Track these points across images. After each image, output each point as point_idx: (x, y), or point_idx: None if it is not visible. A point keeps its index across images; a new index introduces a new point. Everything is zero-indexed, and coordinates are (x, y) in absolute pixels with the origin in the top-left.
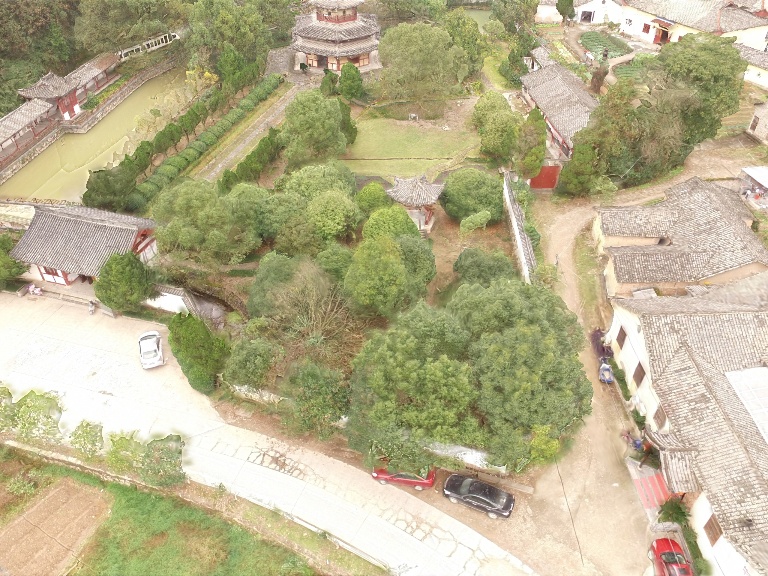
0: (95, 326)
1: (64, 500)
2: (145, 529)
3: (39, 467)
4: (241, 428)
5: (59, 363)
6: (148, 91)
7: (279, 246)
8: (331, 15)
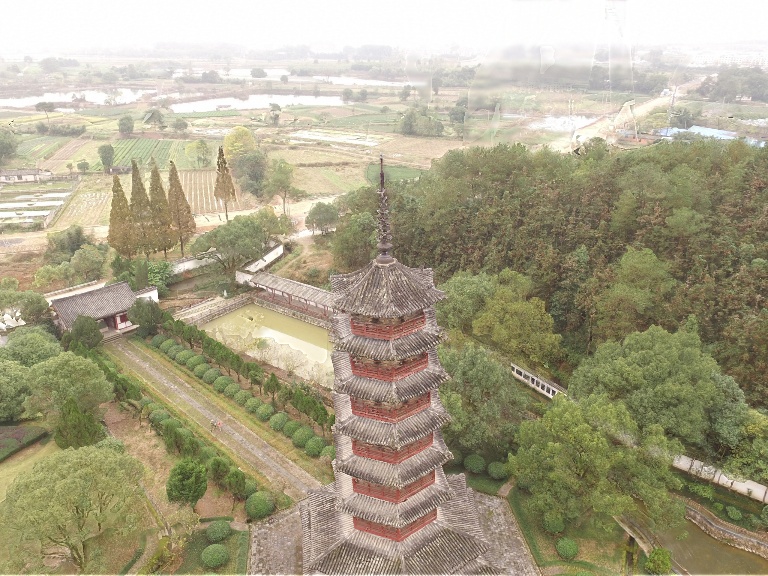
0: None
1: None
2: None
3: None
4: None
5: None
6: None
7: None
8: None
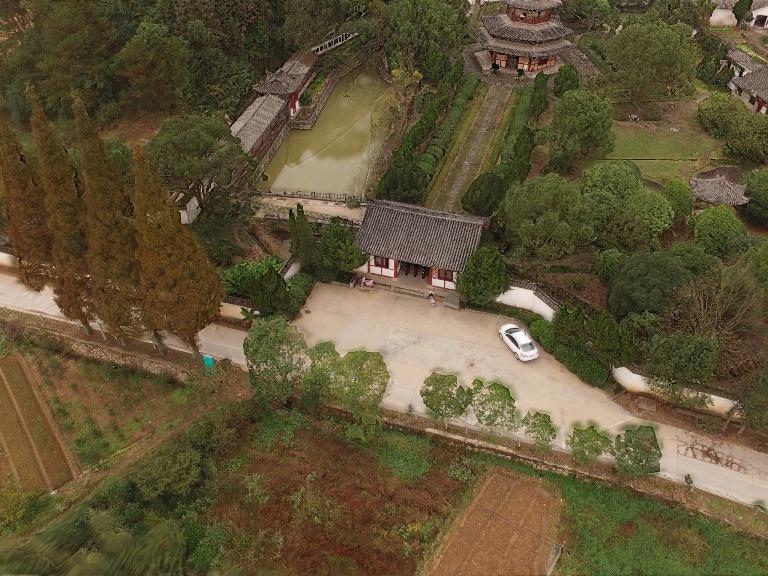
0: (443, 318)
1: (507, 488)
2: (611, 518)
3: (465, 455)
4: (653, 421)
5: (431, 354)
6: (339, 89)
7: (606, 243)
8: (527, 16)
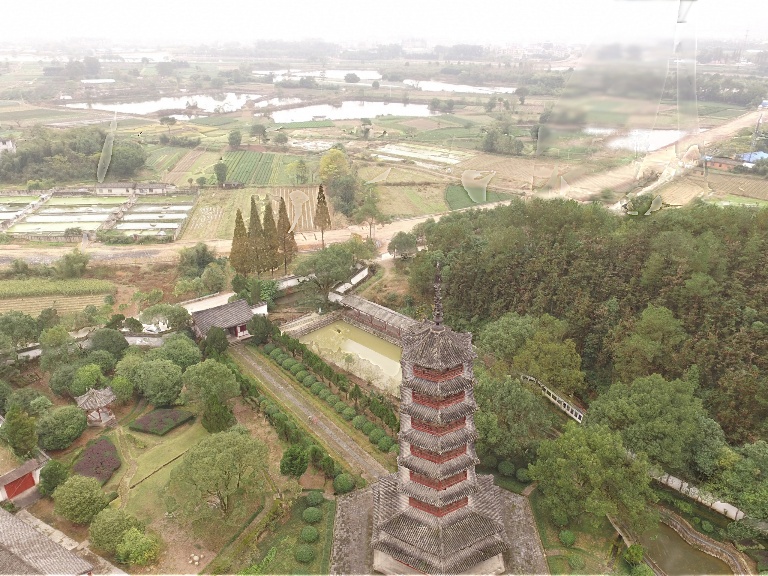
0: None
1: None
2: None
3: None
4: None
5: None
6: None
7: None
8: None
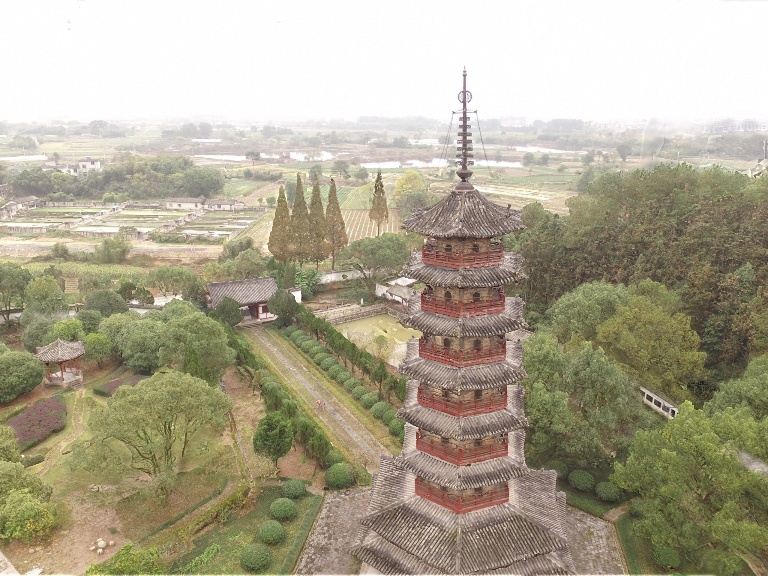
0: None
1: None
2: None
3: None
4: None
5: None
6: None
7: None
8: None
